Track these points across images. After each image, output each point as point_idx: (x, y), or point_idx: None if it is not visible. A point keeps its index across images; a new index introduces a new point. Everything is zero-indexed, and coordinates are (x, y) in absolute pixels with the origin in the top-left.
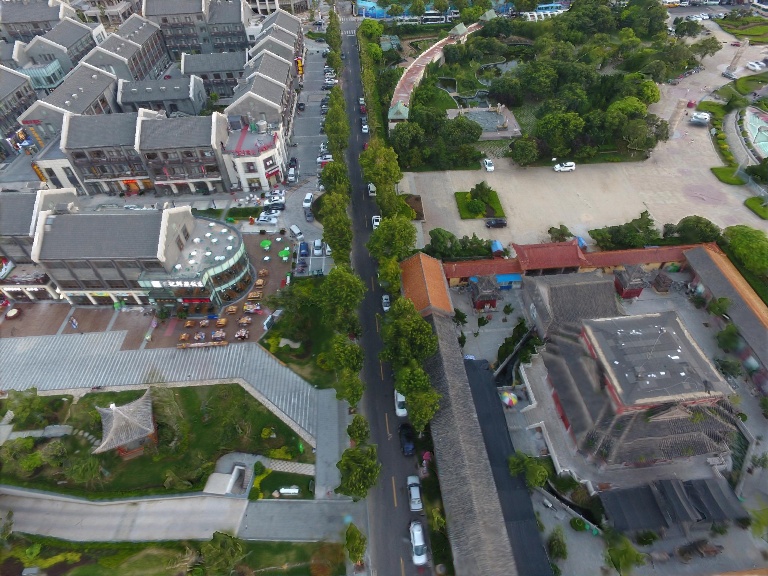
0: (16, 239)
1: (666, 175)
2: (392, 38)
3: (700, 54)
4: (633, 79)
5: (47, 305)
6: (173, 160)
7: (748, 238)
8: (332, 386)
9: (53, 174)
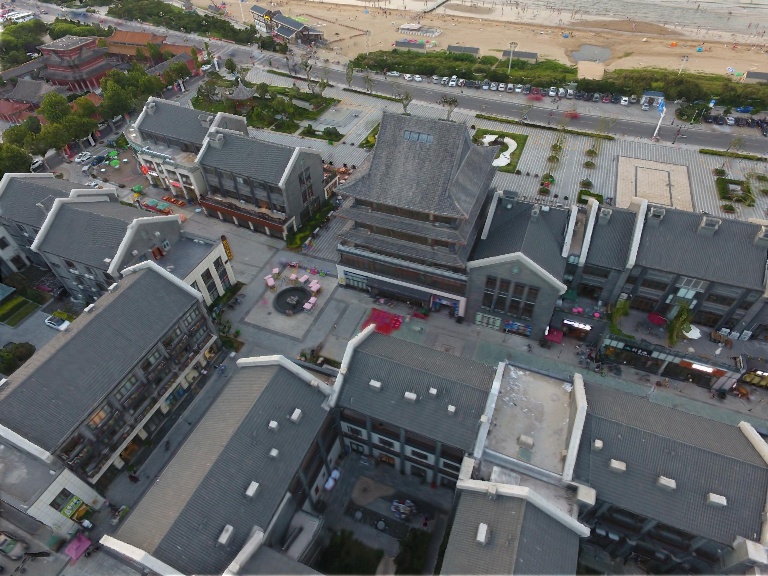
0: None
1: None
2: None
3: None
4: None
5: None
6: None
7: None
8: None
9: None
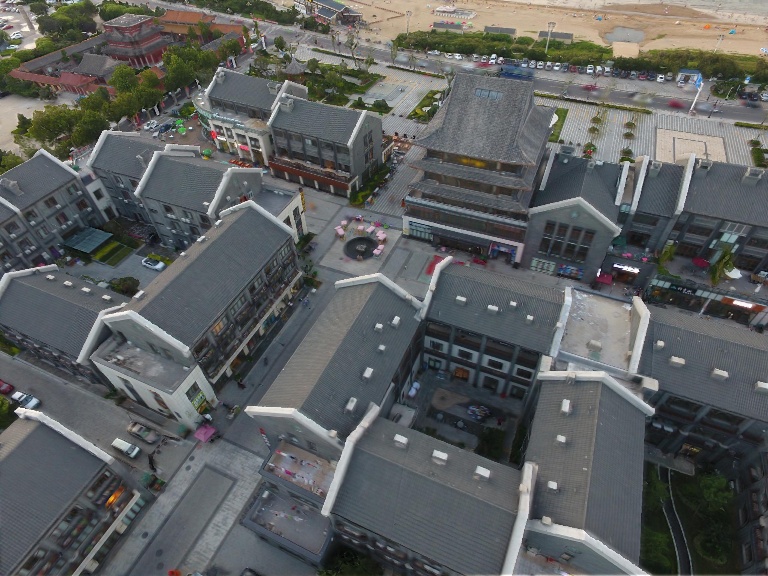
0: None
1: None
2: None
3: None
4: None
5: None
6: None
7: None
8: None
9: None
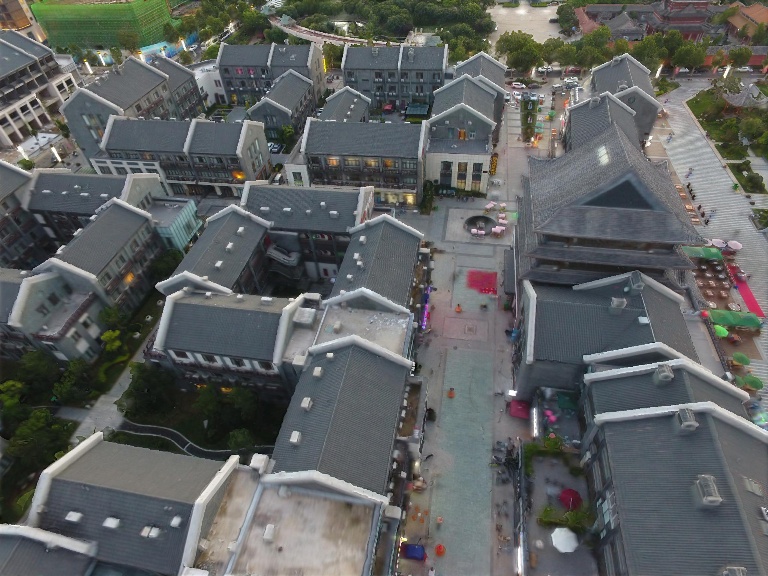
0: None
1: (506, 14)
2: None
3: None
4: None
5: None
6: None
7: (580, 0)
8: (677, 83)
9: None
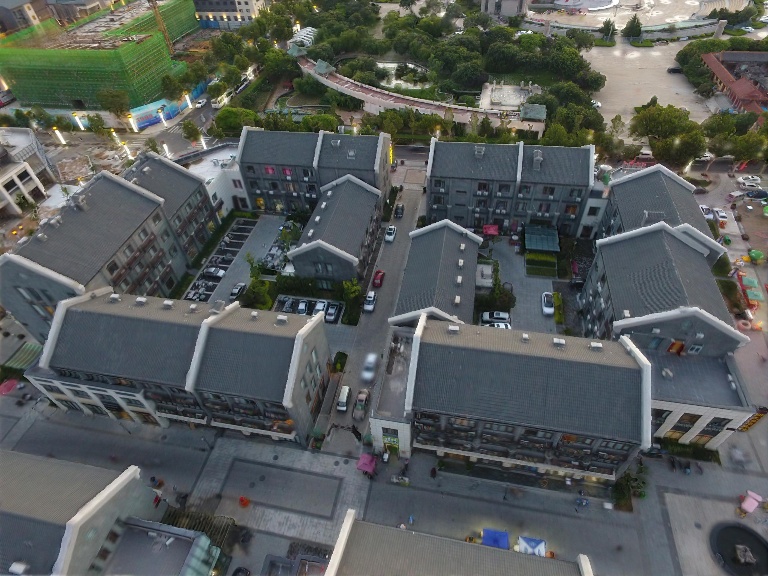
0: None
1: (602, 57)
2: None
3: (436, 11)
4: (477, 32)
5: None
6: None
7: (707, 43)
8: None
9: None
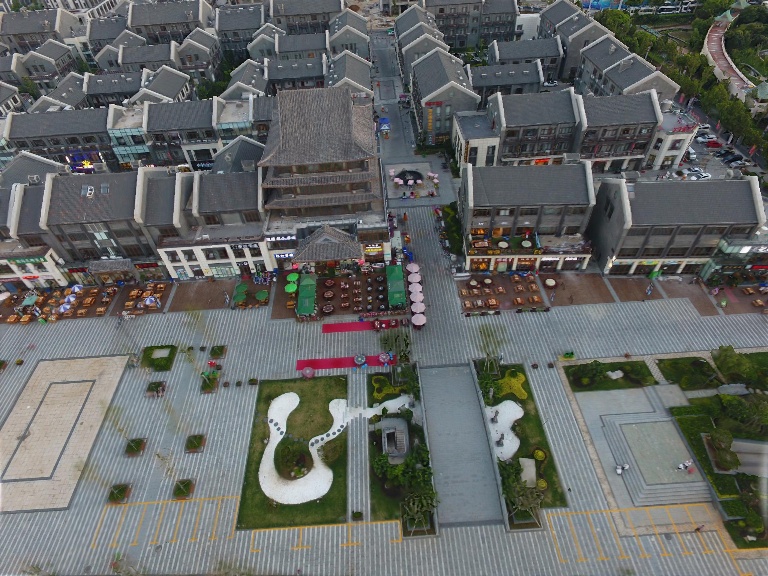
0: (566, 209)
1: None
2: (644, 27)
3: None
4: None
5: (574, 275)
6: (609, 137)
7: None
8: None
9: (471, 153)
